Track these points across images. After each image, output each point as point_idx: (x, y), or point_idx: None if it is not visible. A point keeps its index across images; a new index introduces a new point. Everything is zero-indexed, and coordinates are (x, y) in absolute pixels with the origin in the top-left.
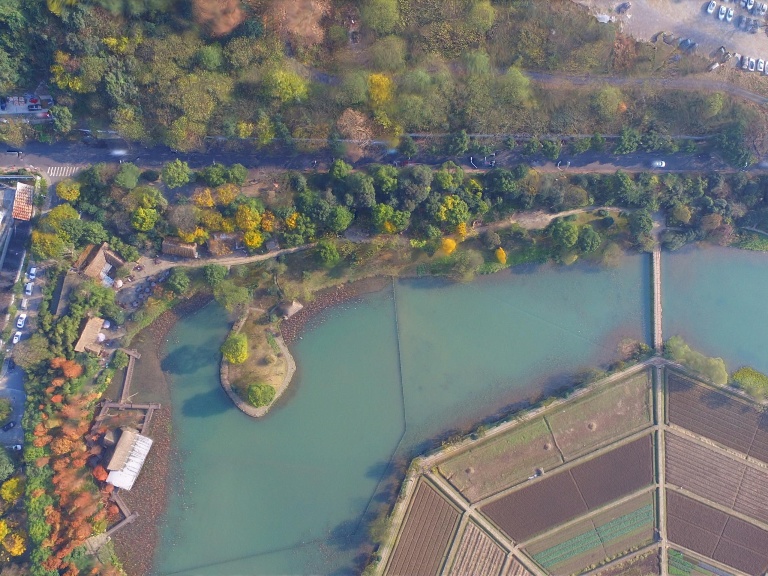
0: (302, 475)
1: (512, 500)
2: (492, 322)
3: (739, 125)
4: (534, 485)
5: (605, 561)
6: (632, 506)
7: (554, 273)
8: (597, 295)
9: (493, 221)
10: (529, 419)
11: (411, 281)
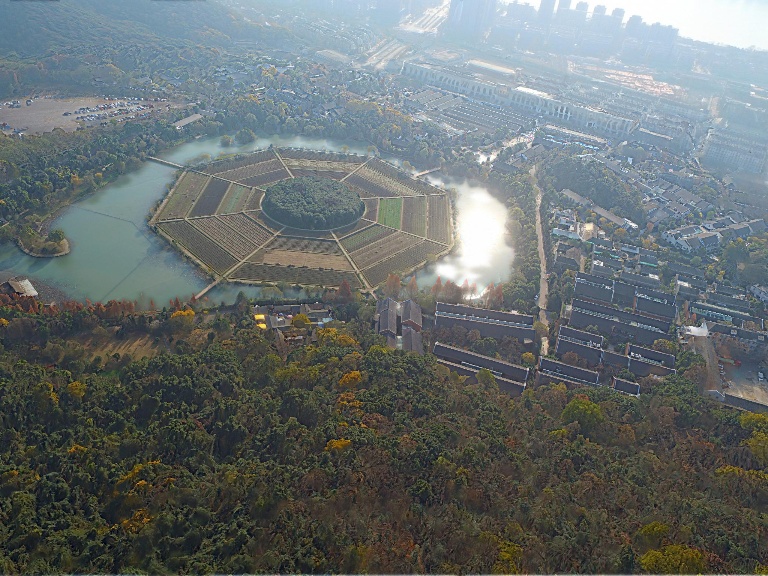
0: (111, 252)
1: None
2: (123, 194)
3: (127, 122)
4: (197, 204)
5: None
6: None
7: (126, 176)
8: (148, 172)
9: (84, 175)
10: None
11: (77, 202)
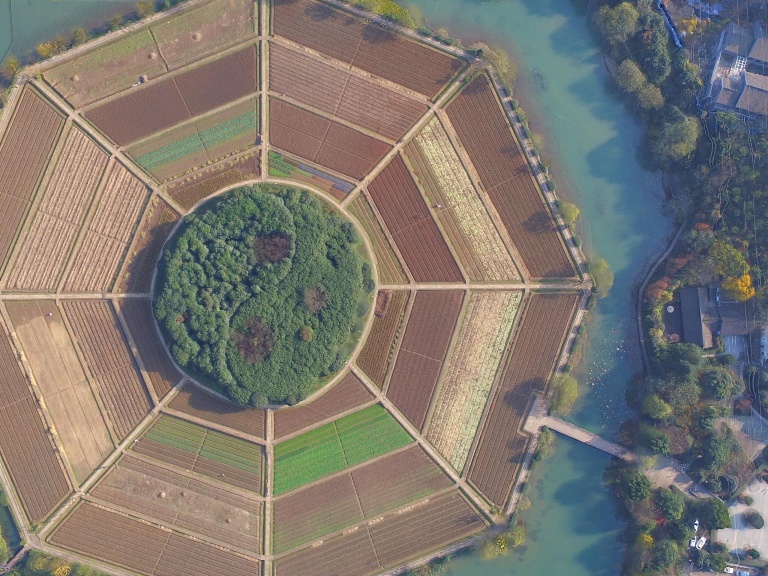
0: None
1: (116, 106)
2: None
3: None
4: (138, 92)
5: (207, 164)
6: (235, 113)
7: None
8: None
9: None
10: (134, 30)
11: None
